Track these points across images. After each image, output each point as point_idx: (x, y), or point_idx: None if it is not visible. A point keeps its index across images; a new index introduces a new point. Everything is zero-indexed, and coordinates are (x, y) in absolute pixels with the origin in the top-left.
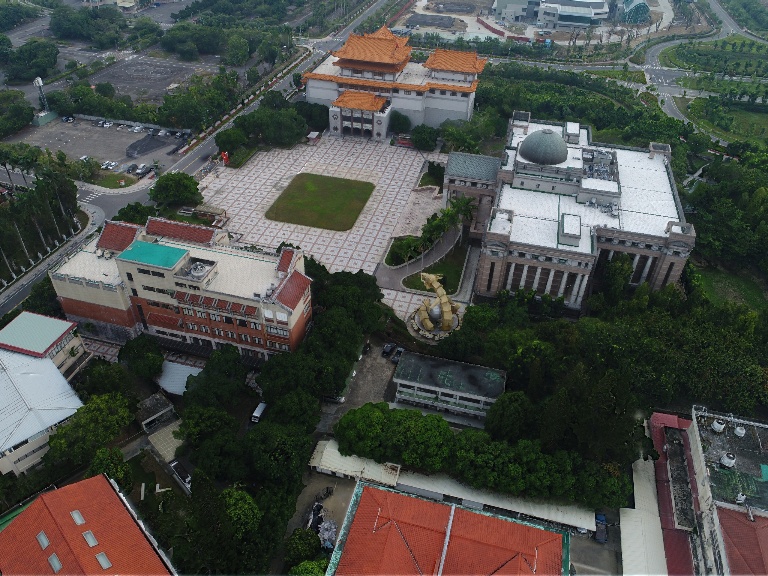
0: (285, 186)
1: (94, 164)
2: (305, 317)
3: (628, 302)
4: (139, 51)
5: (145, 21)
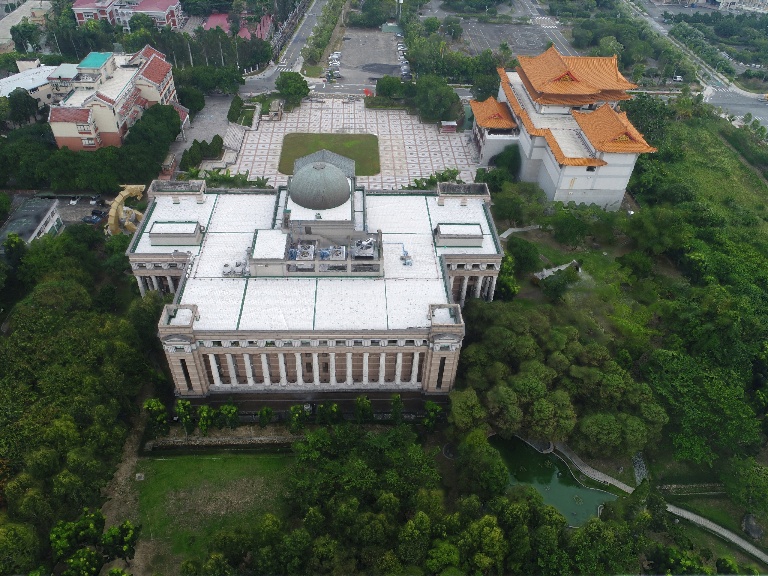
0: (346, 132)
1: (315, 54)
2: (85, 146)
3: (116, 324)
4: (566, 26)
5: (621, 7)
